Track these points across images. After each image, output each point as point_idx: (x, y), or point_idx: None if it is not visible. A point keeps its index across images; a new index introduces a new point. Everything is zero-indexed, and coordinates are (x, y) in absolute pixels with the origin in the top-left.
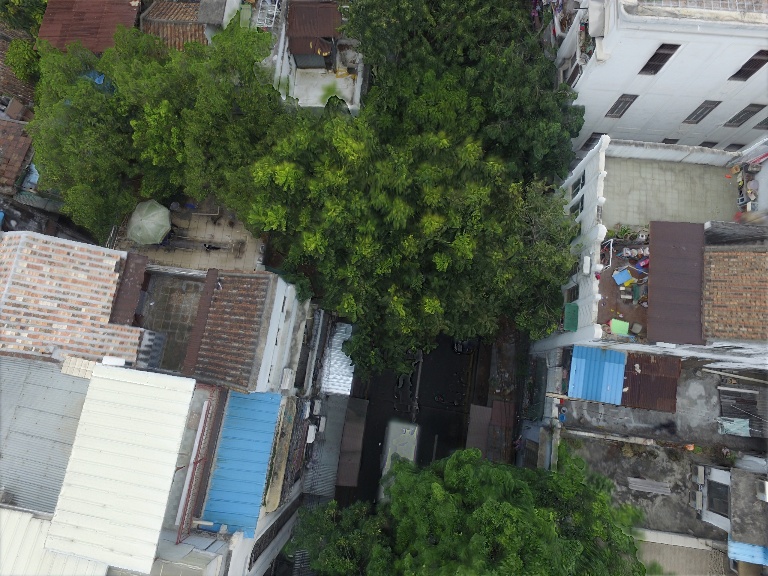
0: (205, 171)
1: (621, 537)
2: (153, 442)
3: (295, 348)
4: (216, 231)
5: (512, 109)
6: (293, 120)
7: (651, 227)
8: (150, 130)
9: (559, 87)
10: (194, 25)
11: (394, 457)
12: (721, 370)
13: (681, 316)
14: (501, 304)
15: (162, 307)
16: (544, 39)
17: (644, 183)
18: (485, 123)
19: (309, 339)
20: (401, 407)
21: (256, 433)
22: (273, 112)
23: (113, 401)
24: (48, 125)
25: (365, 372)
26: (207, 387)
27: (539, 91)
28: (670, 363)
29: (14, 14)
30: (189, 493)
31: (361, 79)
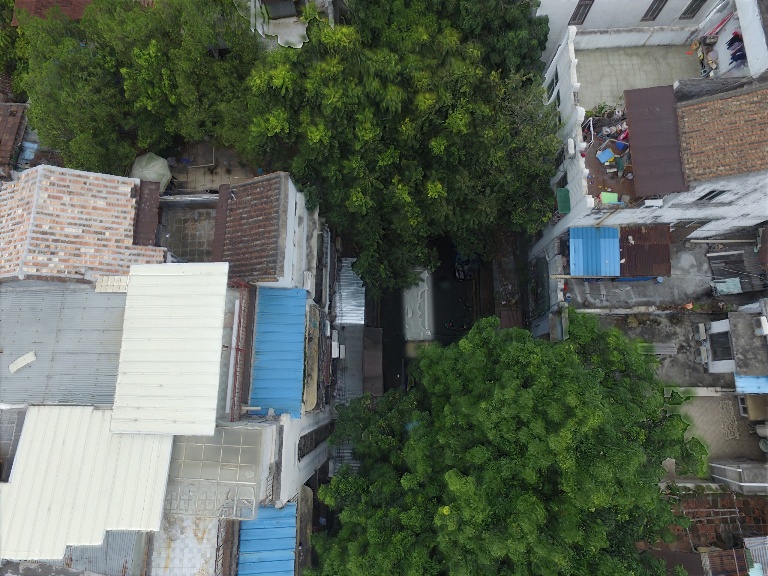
0: (199, 109)
1: (637, 359)
2: (197, 323)
3: (311, 255)
4: None
5: (480, 26)
6: None
7: (625, 96)
8: (141, 76)
9: None
10: None
11: (418, 346)
12: (708, 239)
13: (664, 169)
14: (496, 204)
15: (178, 237)
16: None
17: (613, 69)
18: None
19: (320, 261)
20: (414, 335)
21: (288, 326)
22: (256, 47)
23: (153, 294)
24: (42, 80)
25: (377, 291)
26: (236, 288)
27: (503, 6)
28: (660, 231)
29: None
30: (235, 377)
31: (333, 20)
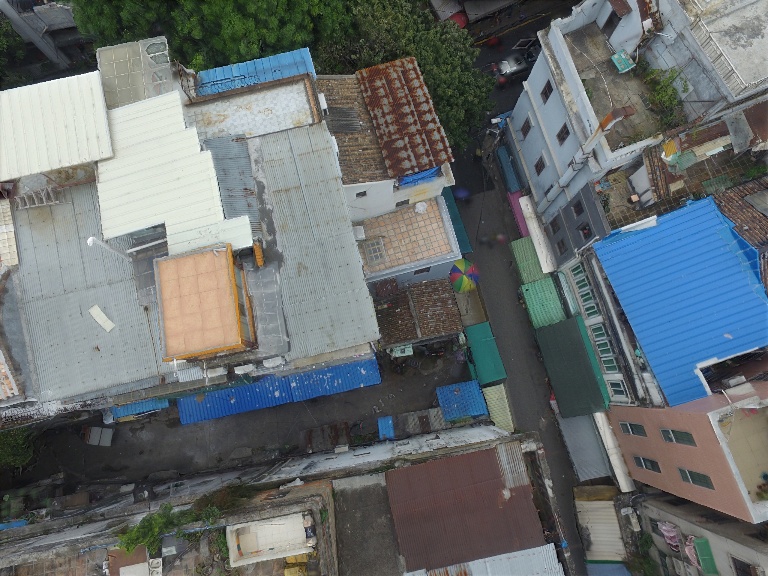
0: None
1: None
2: (7, 113)
3: None
4: None
5: None
6: None
7: None
8: None
9: None
10: None
11: None
12: None
13: None
14: None
15: None
16: None
17: None
18: None
19: None
20: None
21: None
22: None
23: None
24: None
25: None
26: None
27: None
28: None
29: None
30: None
31: None
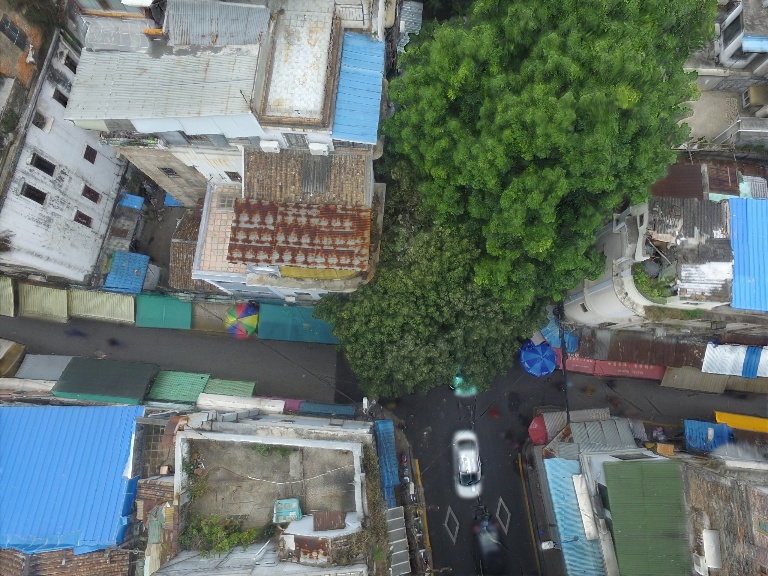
0: None
1: None
2: None
3: None
4: None
5: None
6: None
7: None
8: None
9: None
10: None
11: None
12: None
13: None
14: None
15: None
16: None
17: None
18: None
19: None
20: None
21: None
22: None
23: None
24: None
25: (437, 2)
26: None
27: None
28: None
29: None
30: None
31: None
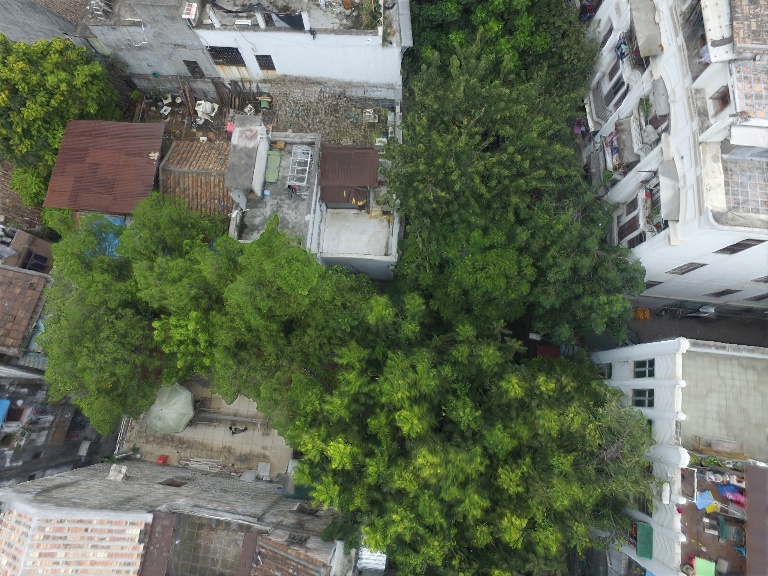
0: (235, 376)
1: None
2: None
3: None
4: (241, 402)
5: None
6: (331, 307)
7: (747, 472)
8: None
9: (620, 252)
10: (218, 176)
11: None
12: None
13: None
14: None
15: (189, 547)
16: (592, 169)
17: (723, 383)
18: (535, 281)
19: None
20: None
21: None
22: (310, 303)
23: None
24: (61, 335)
25: None
26: None
27: (596, 252)
28: None
29: (21, 155)
30: None
31: (398, 225)
